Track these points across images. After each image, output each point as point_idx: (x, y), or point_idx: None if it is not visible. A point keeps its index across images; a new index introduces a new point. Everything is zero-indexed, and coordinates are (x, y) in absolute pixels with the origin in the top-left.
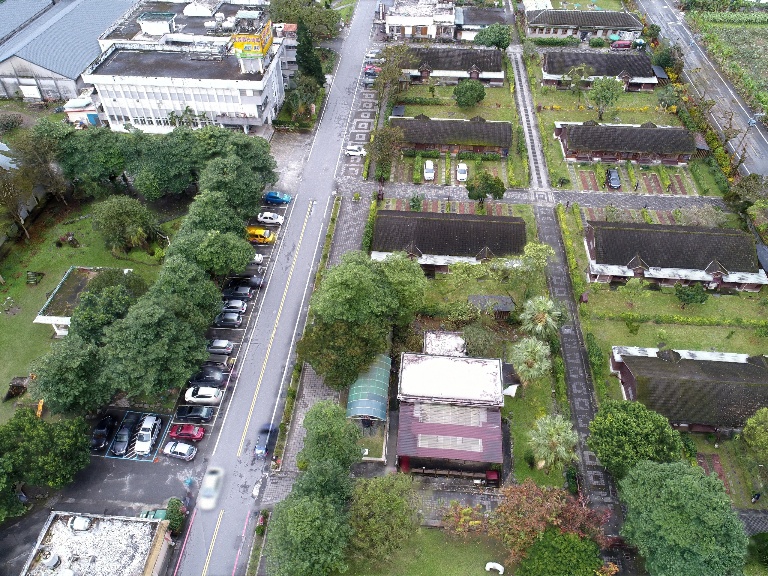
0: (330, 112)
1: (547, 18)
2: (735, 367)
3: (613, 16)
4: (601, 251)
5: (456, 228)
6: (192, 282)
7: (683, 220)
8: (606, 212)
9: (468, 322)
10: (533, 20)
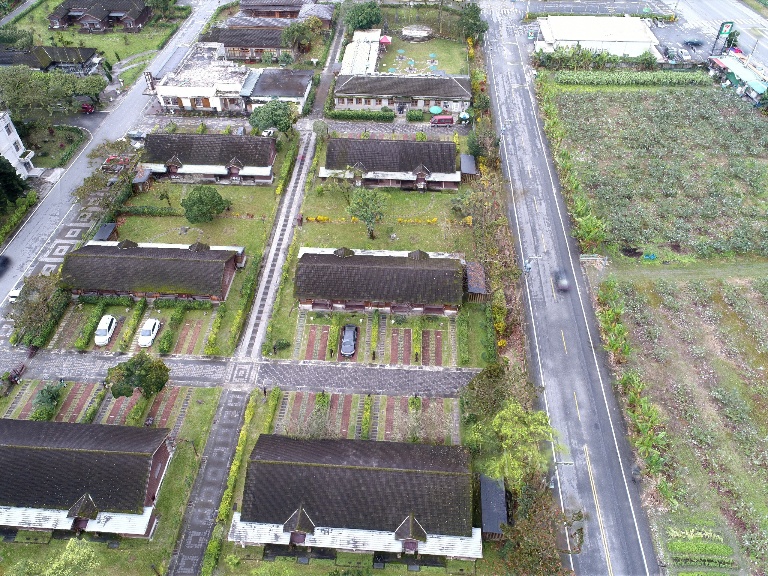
0: (29, 229)
1: (356, 86)
2: None
3: (435, 83)
4: (250, 500)
5: (50, 462)
6: None
7: (402, 427)
8: (286, 423)
9: None
10: (339, 89)
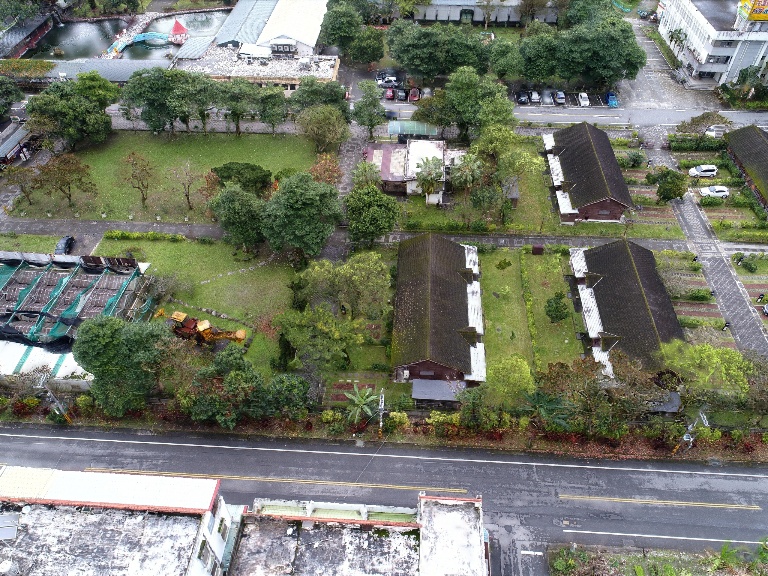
0: None
1: None
2: (458, 308)
3: None
4: (598, 250)
5: (589, 161)
6: (469, 49)
7: None
8: (666, 258)
9: (490, 180)
10: None
